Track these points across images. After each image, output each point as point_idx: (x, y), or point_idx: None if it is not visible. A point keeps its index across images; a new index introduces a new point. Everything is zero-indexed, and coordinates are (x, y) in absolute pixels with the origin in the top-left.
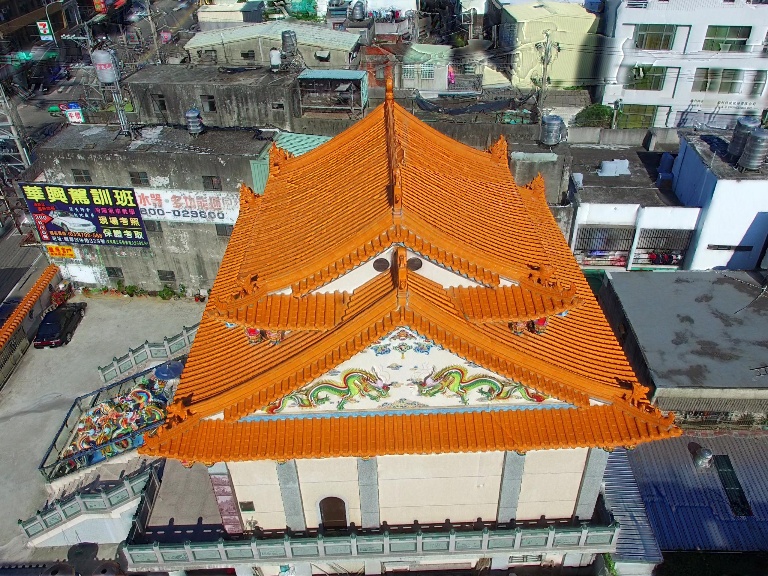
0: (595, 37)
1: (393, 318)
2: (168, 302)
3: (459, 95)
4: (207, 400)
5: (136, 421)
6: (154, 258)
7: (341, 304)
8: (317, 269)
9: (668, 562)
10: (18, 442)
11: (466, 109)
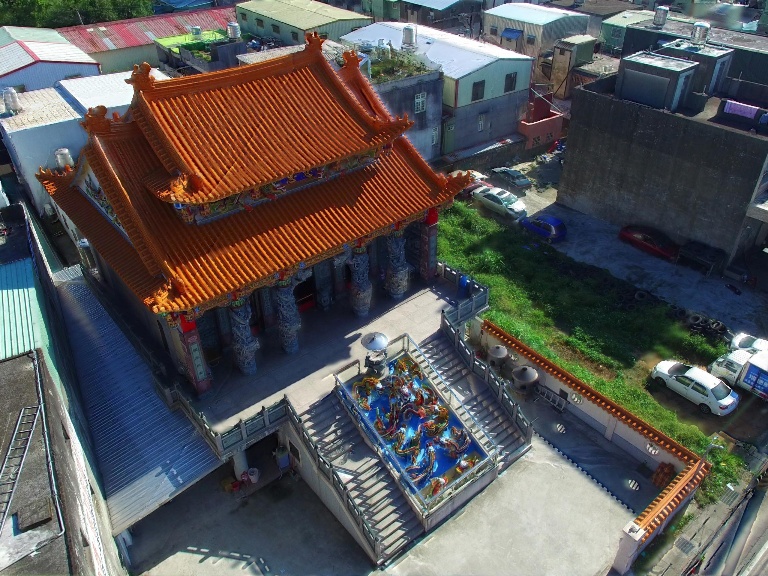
0: None
1: None
2: None
3: None
4: None
5: None
6: None
7: None
8: None
9: None
10: (499, 568)
11: None
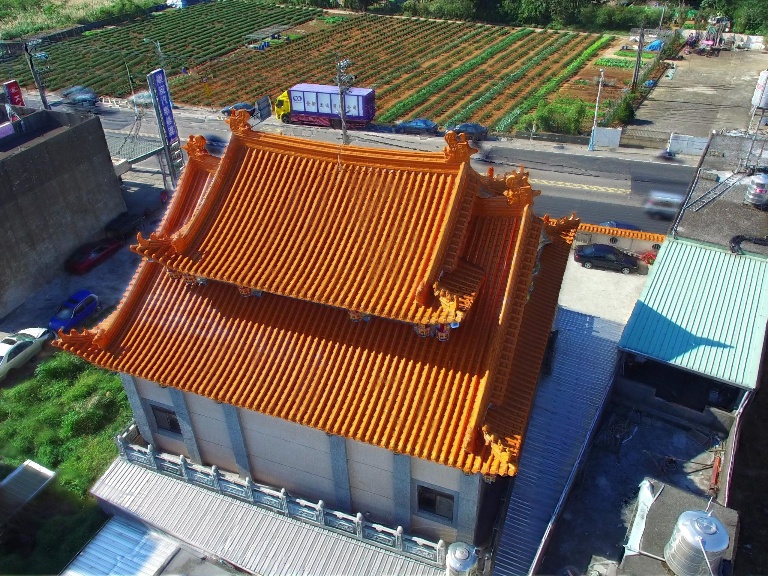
0: None
1: None
2: None
3: None
4: None
5: None
6: None
7: None
8: None
9: (95, 516)
10: None
11: None
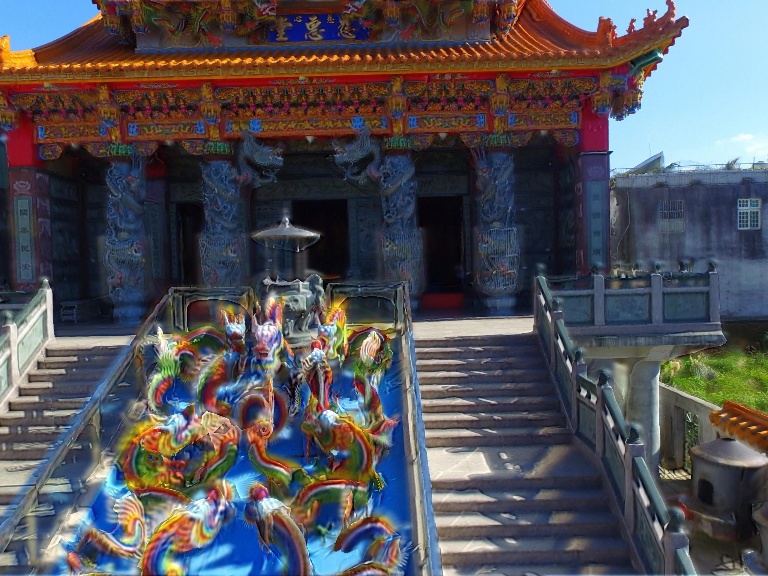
0: None
1: None
2: None
3: None
4: None
5: None
6: None
7: None
8: None
9: None
10: None
11: None
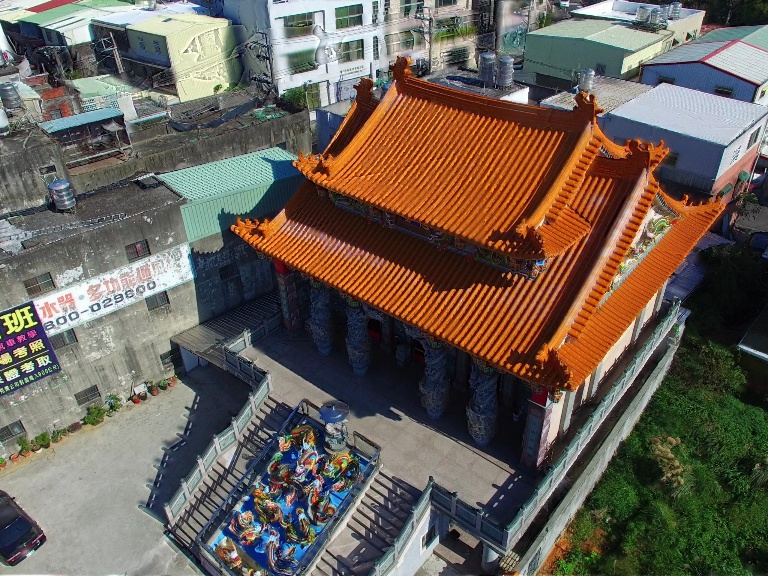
0: (290, 29)
1: (652, 190)
2: (105, 424)
3: (192, 111)
4: (557, 332)
5: (322, 487)
6: (68, 381)
7: (574, 215)
8: (557, 194)
9: None
10: None
11: (221, 119)
